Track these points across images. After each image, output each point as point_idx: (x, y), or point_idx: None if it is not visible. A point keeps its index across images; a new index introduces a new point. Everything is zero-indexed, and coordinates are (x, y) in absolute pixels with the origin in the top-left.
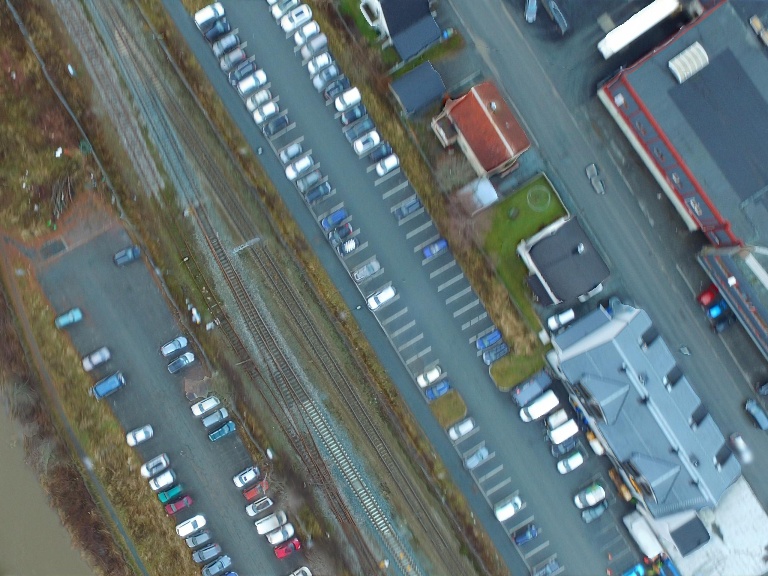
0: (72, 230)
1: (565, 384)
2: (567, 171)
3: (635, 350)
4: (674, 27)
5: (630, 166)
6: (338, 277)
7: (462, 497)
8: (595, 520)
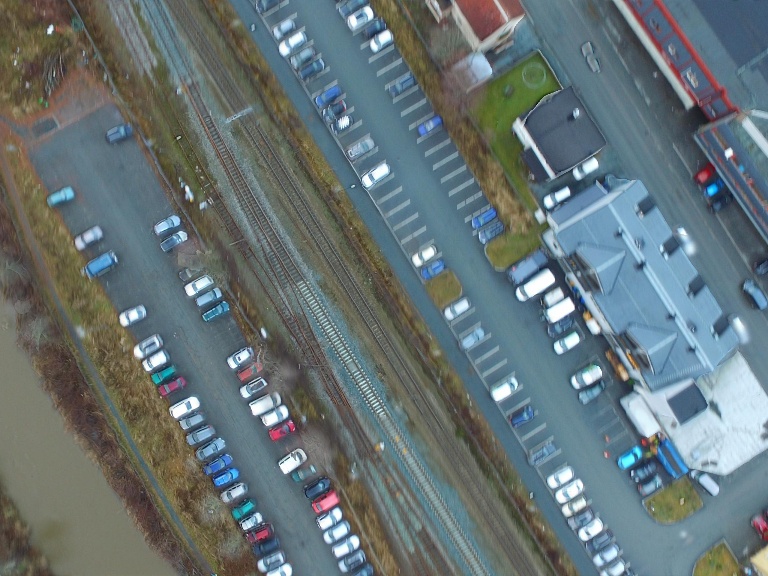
0: (64, 108)
1: (561, 263)
2: (562, 49)
3: (631, 216)
4: None
5: (626, 44)
6: (332, 155)
7: (458, 378)
8: (592, 402)
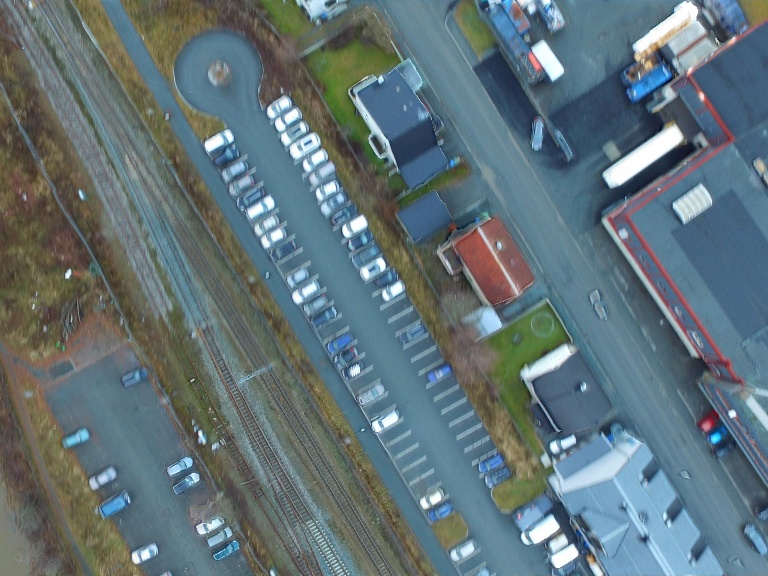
0: (80, 351)
1: None
2: (571, 297)
3: (636, 487)
4: (678, 157)
5: (633, 292)
6: (343, 400)
7: None
8: None
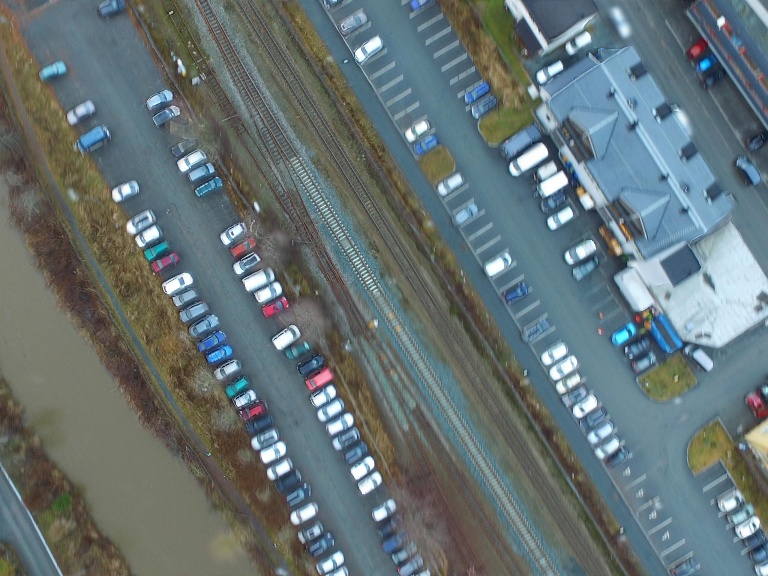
0: None
1: (554, 138)
2: None
3: (624, 78)
4: None
5: None
6: (325, 30)
7: (451, 255)
8: (586, 278)
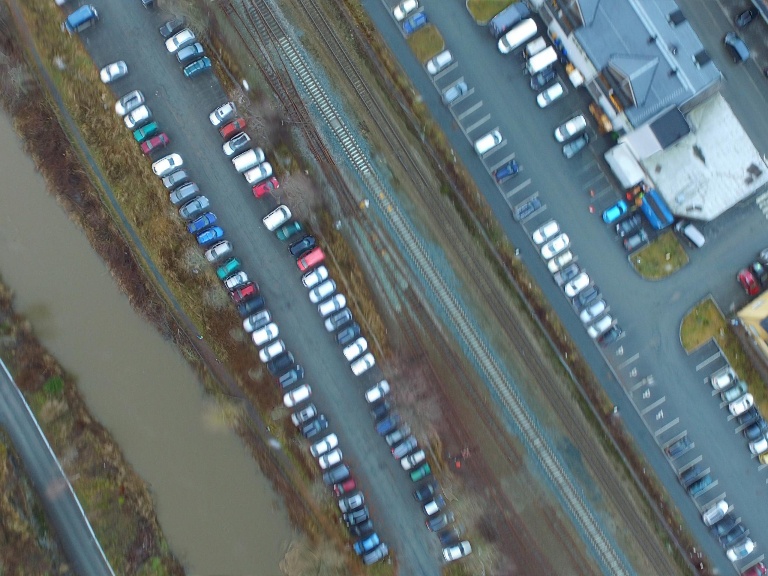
0: None
1: (543, 15)
2: None
3: None
4: None
5: None
6: None
7: (442, 134)
8: (576, 156)
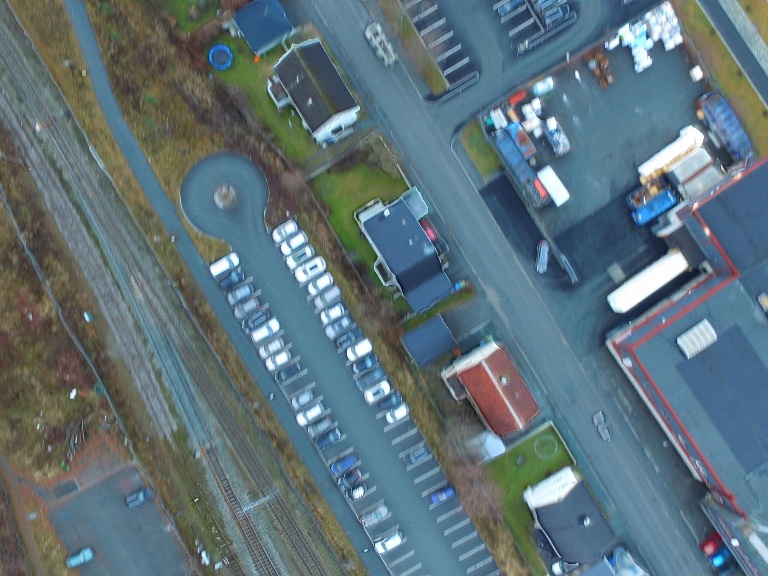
0: (85, 471)
1: None
2: (574, 418)
3: None
4: (683, 280)
5: (637, 414)
6: (346, 520)
7: None
8: None
